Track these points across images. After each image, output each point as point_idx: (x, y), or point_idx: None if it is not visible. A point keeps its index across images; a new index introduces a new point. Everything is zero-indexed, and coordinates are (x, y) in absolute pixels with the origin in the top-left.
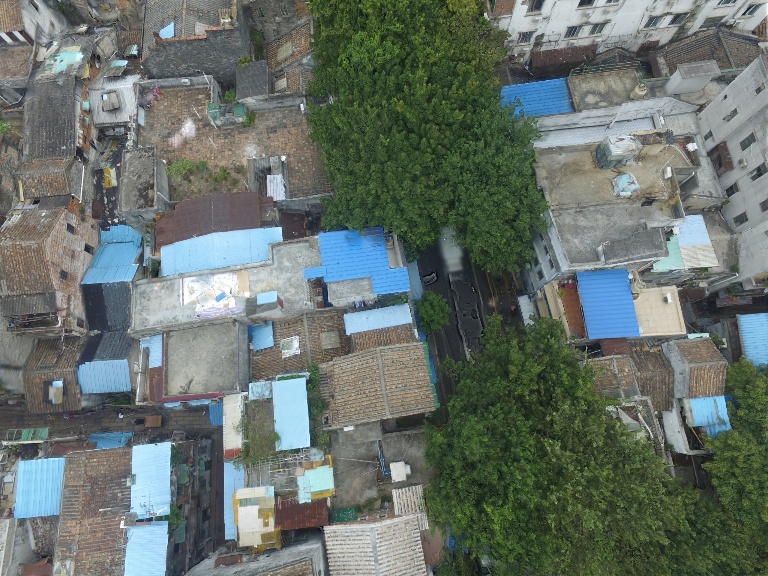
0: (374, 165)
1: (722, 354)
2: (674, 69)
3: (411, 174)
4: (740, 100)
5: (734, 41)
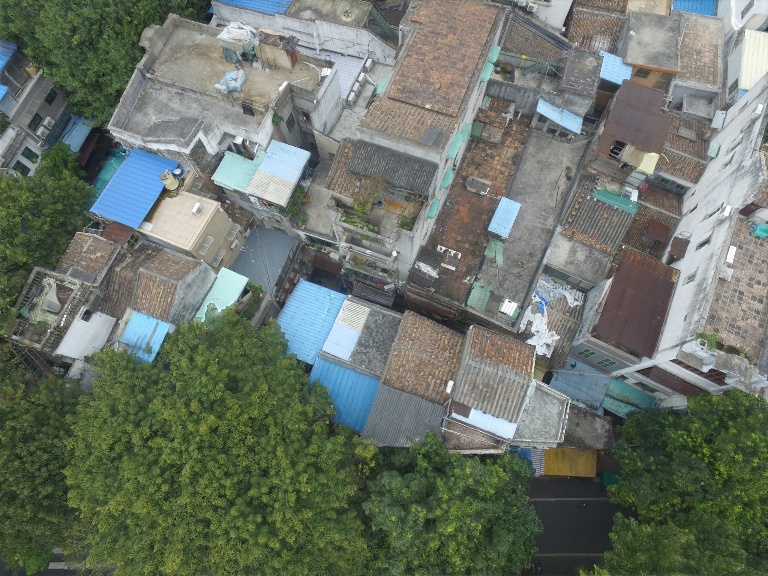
0: None
1: None
2: None
3: None
4: None
5: (528, 30)
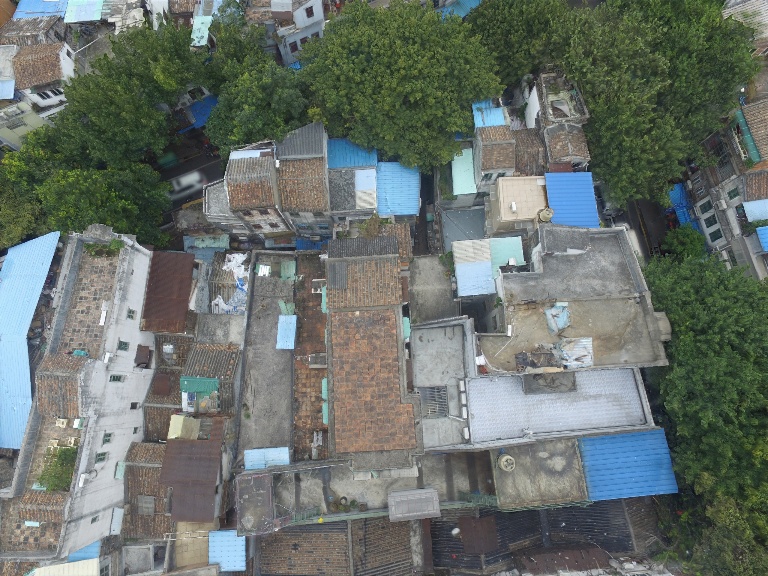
0: None
1: None
2: (406, 541)
3: None
4: None
5: None
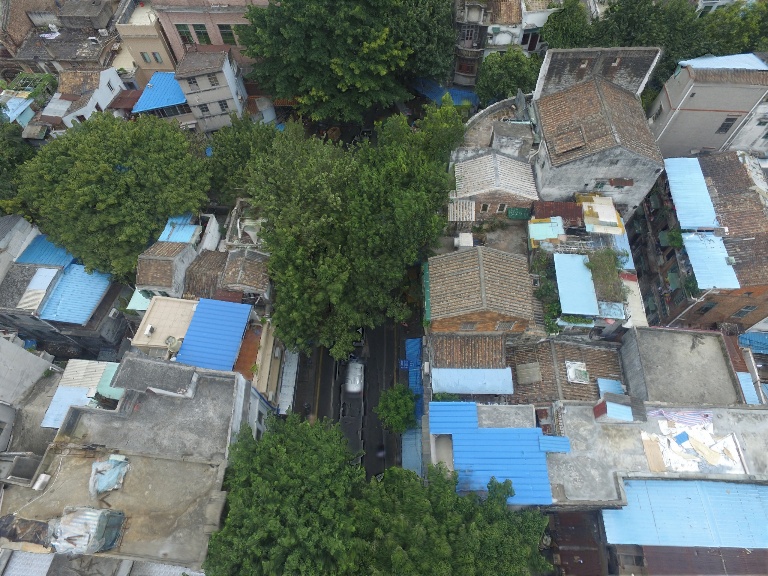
0: (470, 575)
1: None
2: None
3: (409, 553)
4: None
5: None
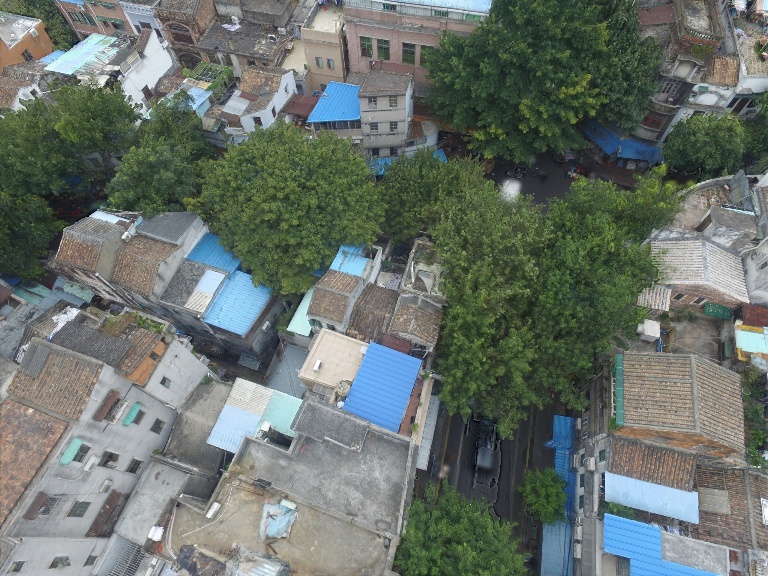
0: None
1: (271, 320)
2: None
3: None
4: (37, 575)
5: None
